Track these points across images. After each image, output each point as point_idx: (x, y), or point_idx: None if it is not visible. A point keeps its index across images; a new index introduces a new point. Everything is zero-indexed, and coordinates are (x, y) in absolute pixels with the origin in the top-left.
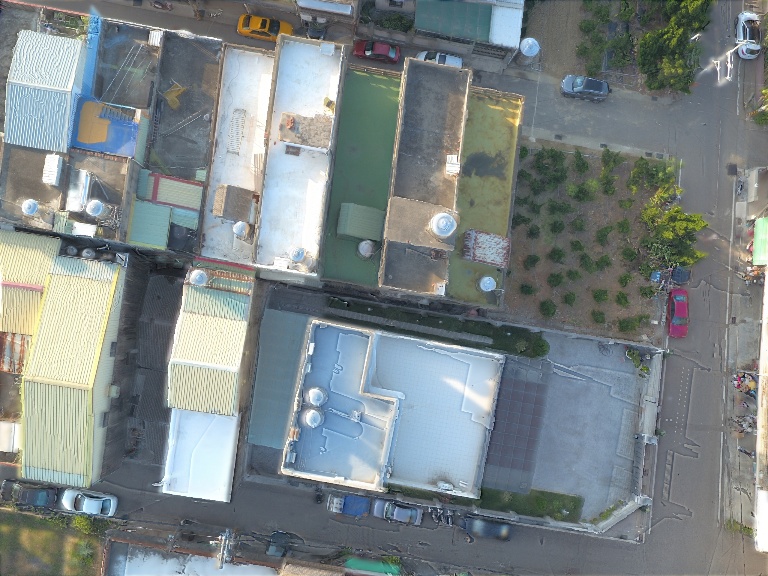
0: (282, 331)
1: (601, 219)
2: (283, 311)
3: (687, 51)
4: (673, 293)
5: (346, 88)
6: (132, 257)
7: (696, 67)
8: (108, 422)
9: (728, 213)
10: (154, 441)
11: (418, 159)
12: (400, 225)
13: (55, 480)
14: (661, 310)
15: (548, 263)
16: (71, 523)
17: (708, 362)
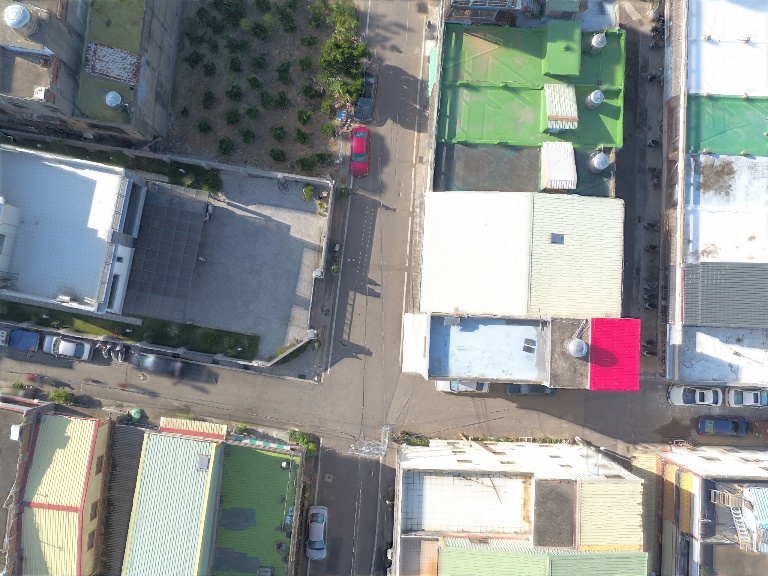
0: None
1: (286, 58)
2: None
3: None
4: (354, 130)
5: None
6: None
7: None
8: None
9: (417, 51)
10: None
11: None
12: None
13: None
14: (346, 149)
15: (230, 103)
16: None
17: (394, 202)
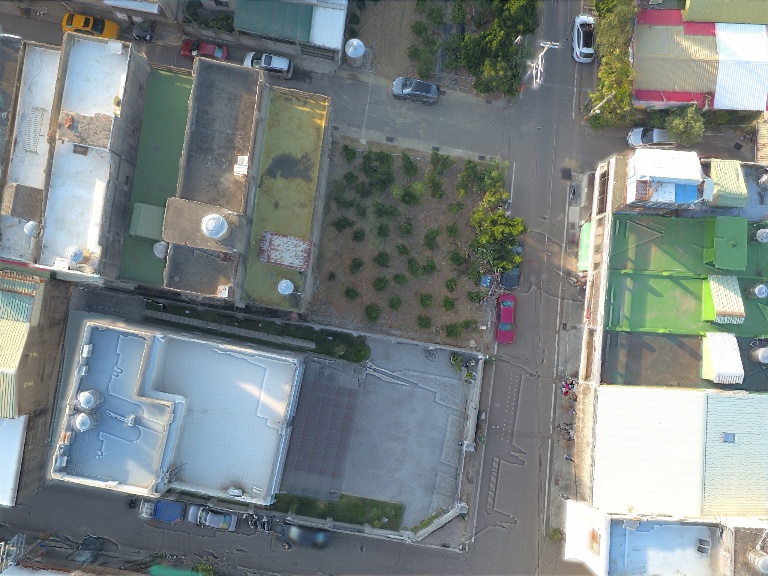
0: None
1: (431, 223)
2: (90, 312)
3: (512, 54)
4: (501, 298)
5: (150, 87)
6: None
7: (522, 70)
8: None
9: (561, 218)
10: None
11: (208, 160)
12: (177, 226)
13: None
14: None
15: (376, 267)
16: None
17: (537, 368)
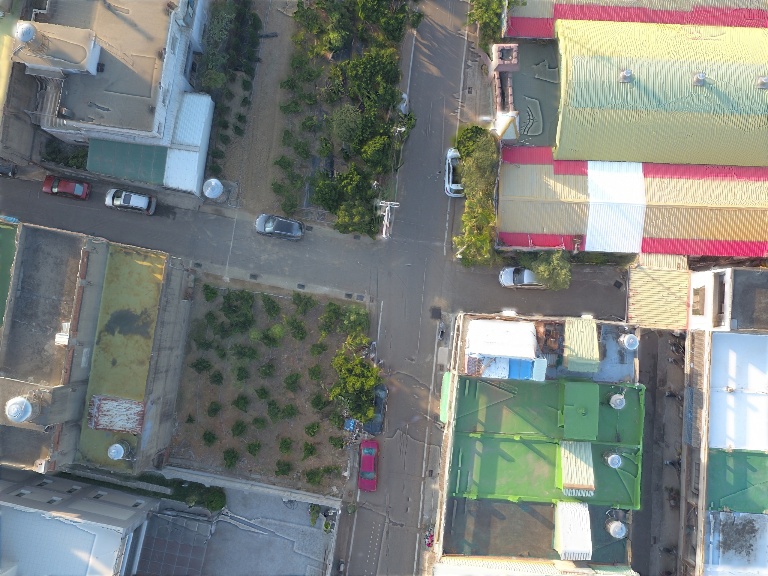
0: None
1: (295, 363)
2: None
3: (372, 196)
4: (362, 445)
5: None
6: None
7: None
8: None
9: (429, 359)
10: None
11: (33, 326)
12: None
13: None
14: (353, 461)
15: (236, 409)
16: None
17: (401, 517)
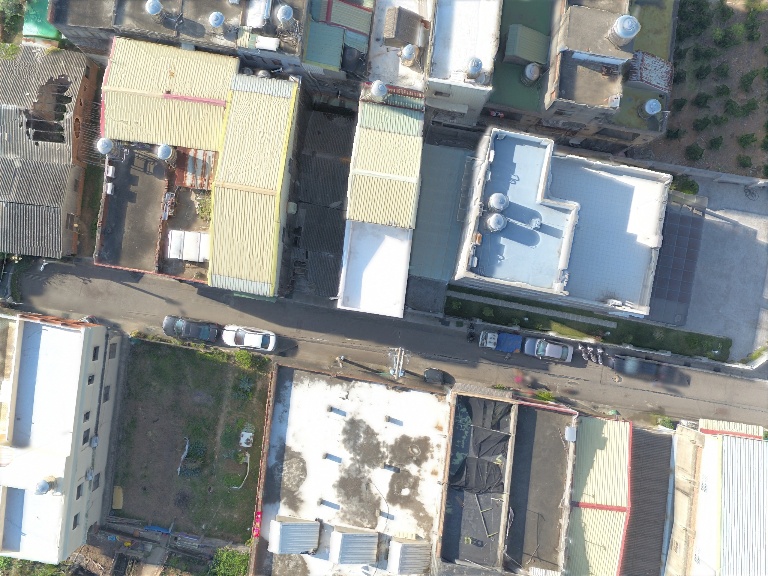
0: (440, 165)
1: (745, 66)
2: (440, 146)
3: None
4: None
5: None
6: (305, 80)
7: None
8: (284, 239)
9: None
10: (316, 272)
11: None
12: (579, 33)
13: (240, 288)
14: None
15: (692, 109)
16: (229, 359)
17: None
